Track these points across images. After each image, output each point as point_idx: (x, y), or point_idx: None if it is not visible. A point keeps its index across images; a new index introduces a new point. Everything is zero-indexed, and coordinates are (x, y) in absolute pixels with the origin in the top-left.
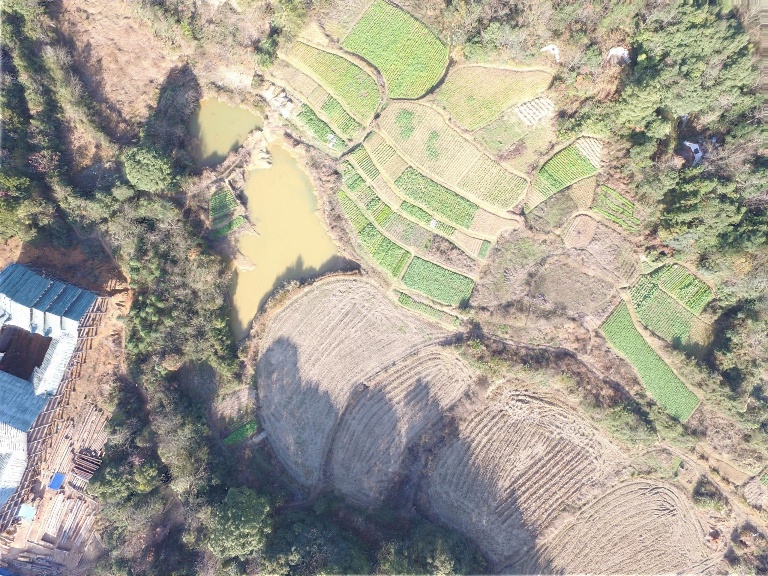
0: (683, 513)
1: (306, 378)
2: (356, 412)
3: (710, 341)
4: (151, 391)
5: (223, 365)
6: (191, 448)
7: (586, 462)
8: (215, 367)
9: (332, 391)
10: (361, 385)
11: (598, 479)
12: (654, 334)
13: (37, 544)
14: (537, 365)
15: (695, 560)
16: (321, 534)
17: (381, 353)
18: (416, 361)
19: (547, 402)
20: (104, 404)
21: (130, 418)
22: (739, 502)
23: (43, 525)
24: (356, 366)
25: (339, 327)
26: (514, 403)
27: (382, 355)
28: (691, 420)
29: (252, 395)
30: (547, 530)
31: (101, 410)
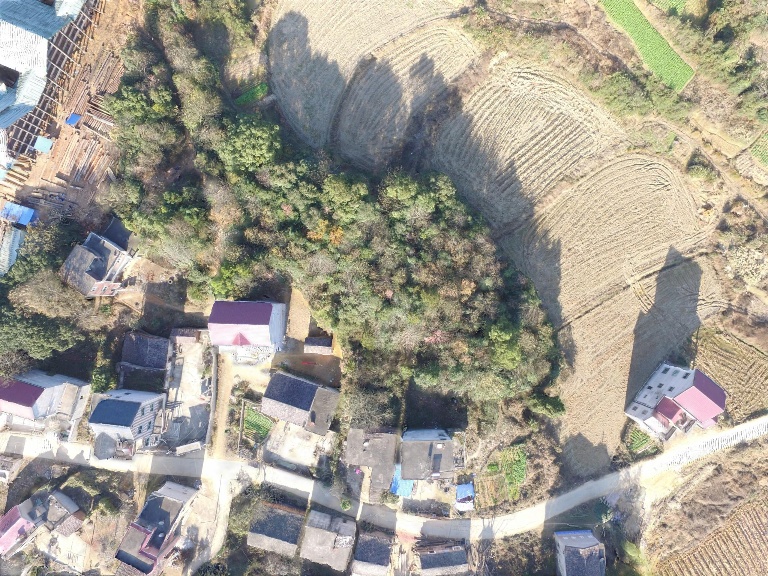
0: (677, 188)
1: (316, 47)
2: (363, 82)
3: (705, 13)
4: (167, 33)
5: (237, 21)
6: (204, 85)
7: (584, 136)
8: (229, 28)
9: (341, 60)
10: (369, 54)
11: (595, 152)
12: (651, 3)
13: (51, 182)
14: (539, 34)
15: (688, 233)
16: (328, 163)
17: (389, 26)
18: (422, 36)
19: (548, 79)
20: None
21: (146, 51)
22: (731, 175)
23: (57, 164)
24: (365, 37)
25: (349, 1)
26: (516, 79)
27: (390, 27)
28: (686, 90)
29: (264, 59)
30: (545, 198)
31: (118, 57)
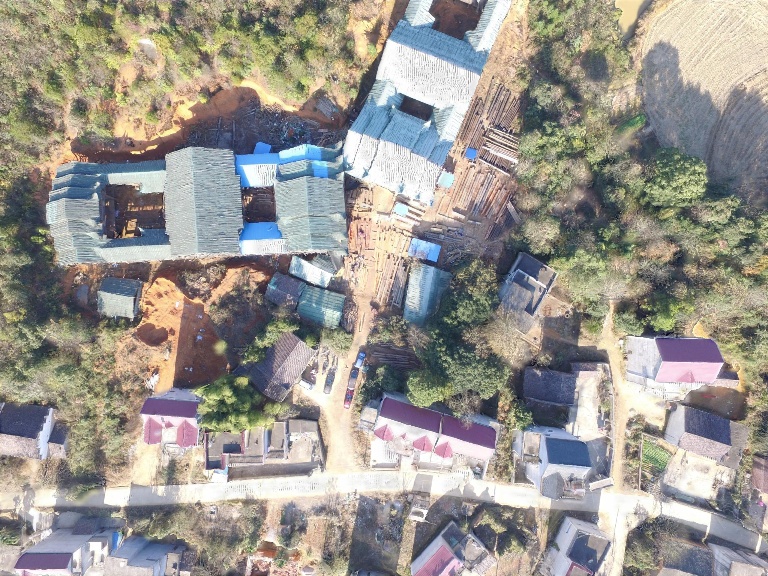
0: None
1: (688, 78)
2: (734, 112)
3: None
4: (566, 66)
5: (622, 53)
6: None
7: None
8: (608, 60)
9: (713, 90)
10: (742, 84)
11: None
12: None
13: (448, 217)
14: None
15: None
16: None
17: (759, 56)
18: None
19: None
20: (512, 84)
21: None
22: None
23: (454, 199)
24: (736, 67)
25: (718, 31)
26: None
27: (760, 58)
28: None
29: (640, 90)
30: None
31: (508, 90)
